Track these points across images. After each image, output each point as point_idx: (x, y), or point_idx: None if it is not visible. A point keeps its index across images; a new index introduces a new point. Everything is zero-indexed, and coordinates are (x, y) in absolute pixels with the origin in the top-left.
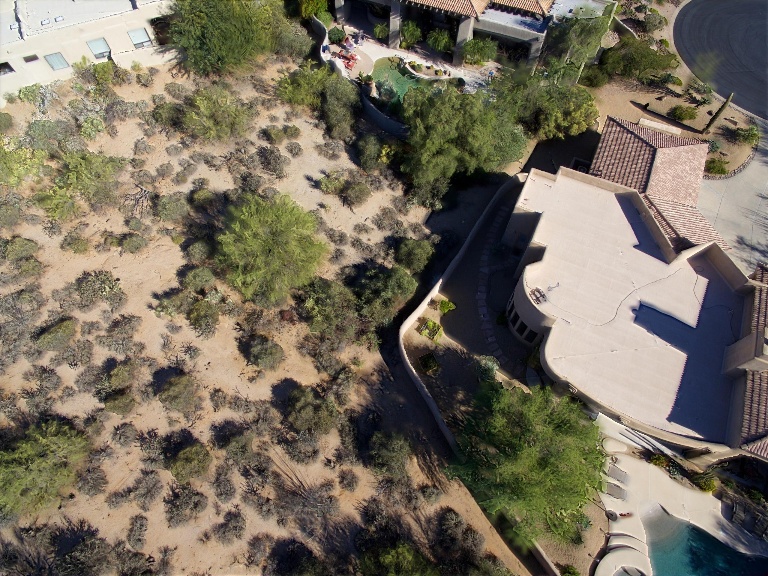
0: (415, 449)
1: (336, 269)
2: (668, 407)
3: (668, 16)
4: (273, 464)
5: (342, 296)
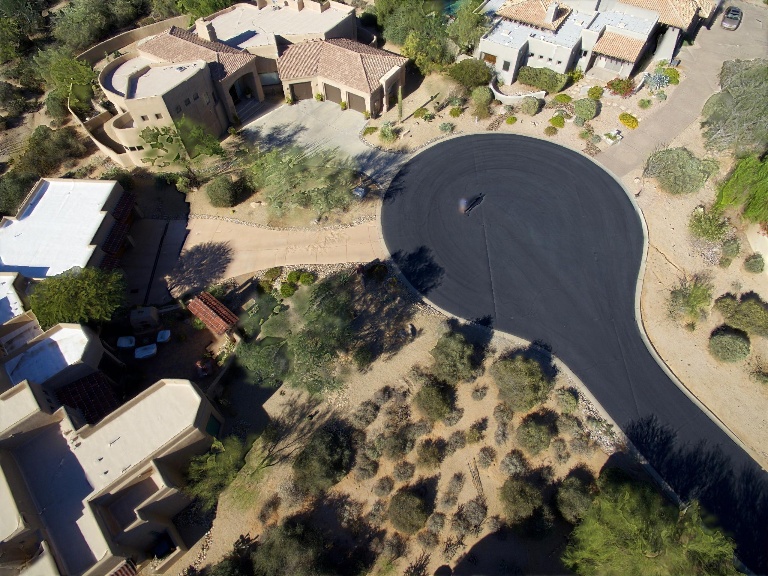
0: None
1: None
2: None
3: (564, 140)
4: None
5: None
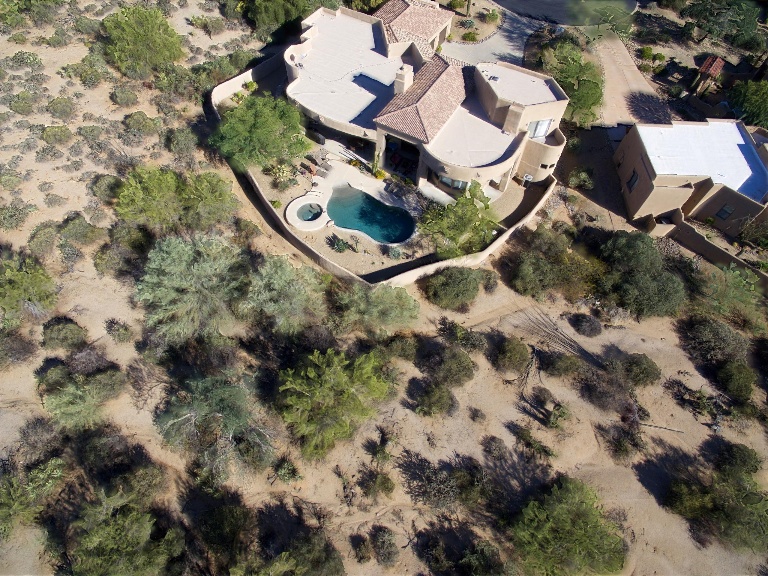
0: (206, 149)
1: (189, 66)
2: (353, 117)
3: None
4: (111, 145)
5: (183, 71)
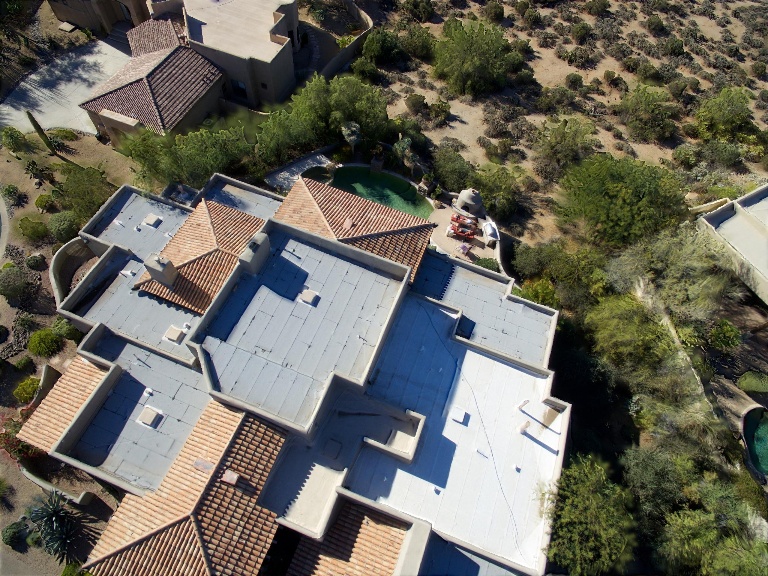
0: (361, 1)
1: None
2: None
3: None
4: None
5: None
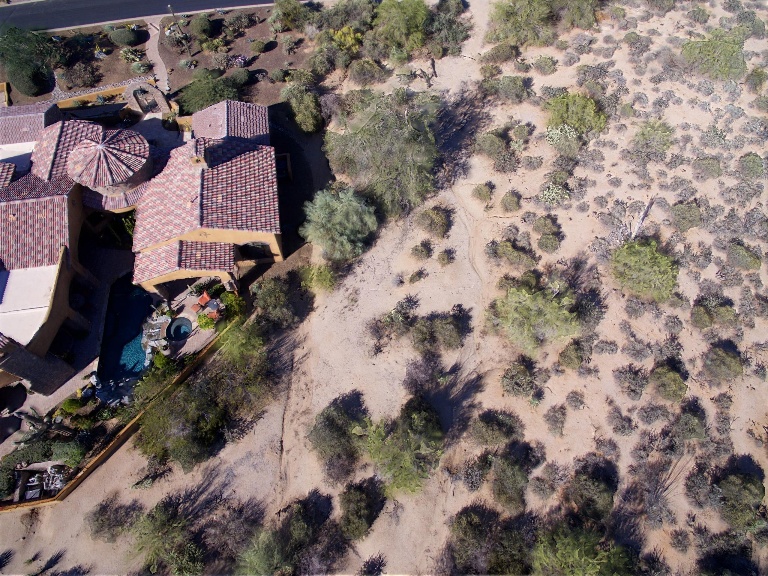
0: None
1: None
2: None
3: None
4: (678, 459)
5: None
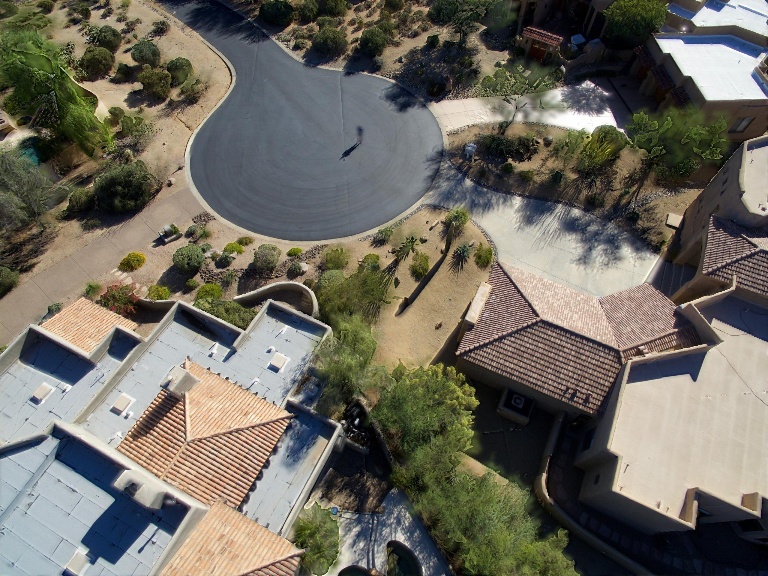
0: None
1: None
2: None
3: (233, 233)
4: None
5: None
